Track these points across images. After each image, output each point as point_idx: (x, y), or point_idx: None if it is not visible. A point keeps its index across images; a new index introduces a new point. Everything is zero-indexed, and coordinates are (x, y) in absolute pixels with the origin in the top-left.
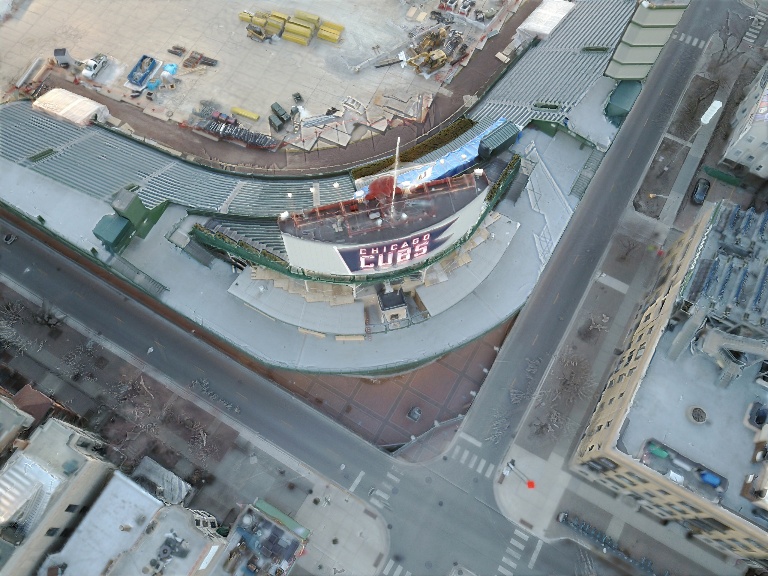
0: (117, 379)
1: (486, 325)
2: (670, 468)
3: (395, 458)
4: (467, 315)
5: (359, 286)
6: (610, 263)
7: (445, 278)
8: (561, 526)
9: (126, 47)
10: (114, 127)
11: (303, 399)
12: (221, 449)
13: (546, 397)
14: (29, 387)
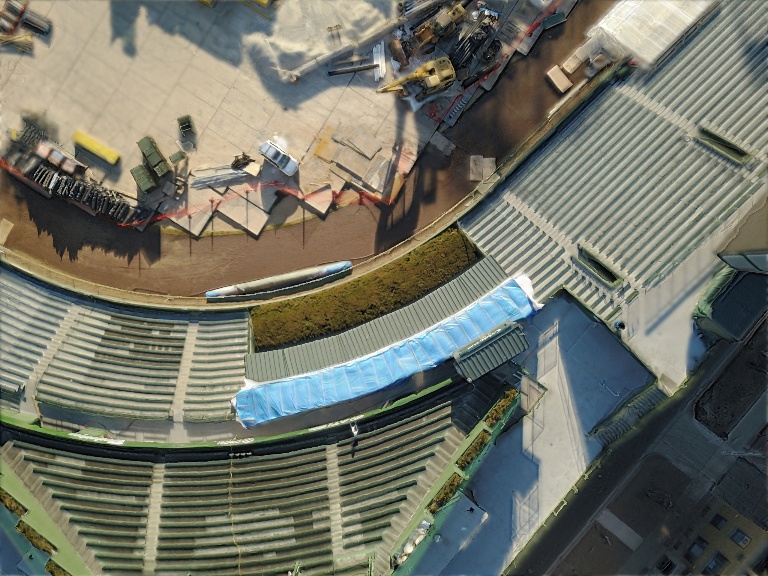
0: None
1: None
2: None
3: None
4: None
5: None
6: (627, 500)
7: None
8: None
9: None
10: None
11: None
12: None
13: None
14: None
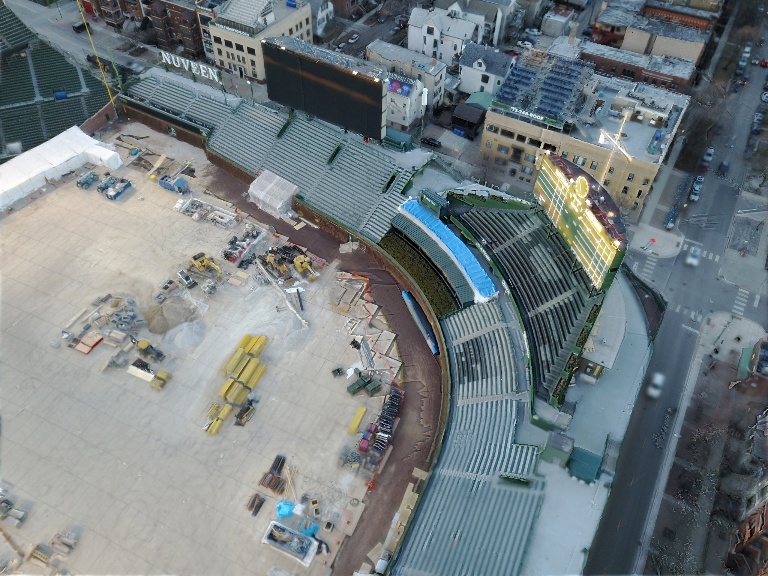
0: (680, 516)
1: None
2: (656, 150)
3: None
4: None
5: None
6: None
7: None
8: (672, 230)
9: (239, 575)
10: (375, 569)
11: None
12: (705, 420)
13: None
14: (765, 526)
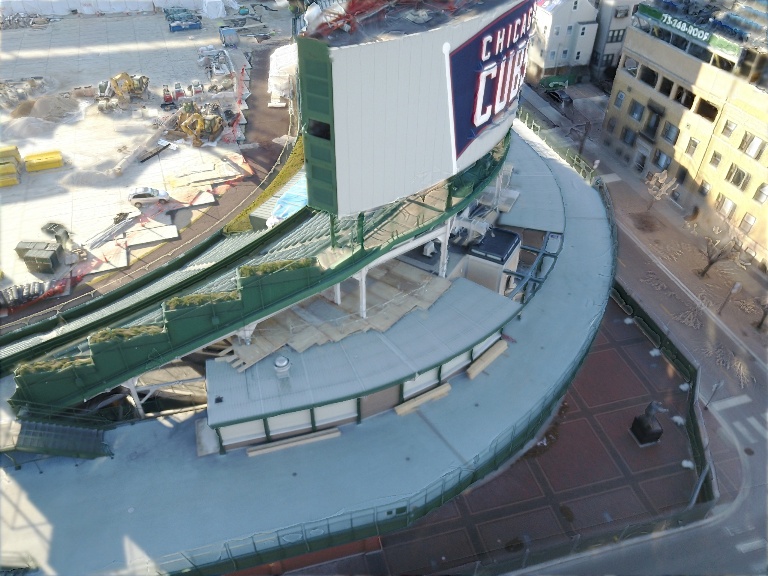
0: None
1: (601, 232)
2: None
3: (713, 516)
4: (569, 238)
5: (430, 264)
6: None
7: (515, 193)
8: None
9: None
10: None
11: (490, 570)
12: None
13: (711, 297)
14: None
